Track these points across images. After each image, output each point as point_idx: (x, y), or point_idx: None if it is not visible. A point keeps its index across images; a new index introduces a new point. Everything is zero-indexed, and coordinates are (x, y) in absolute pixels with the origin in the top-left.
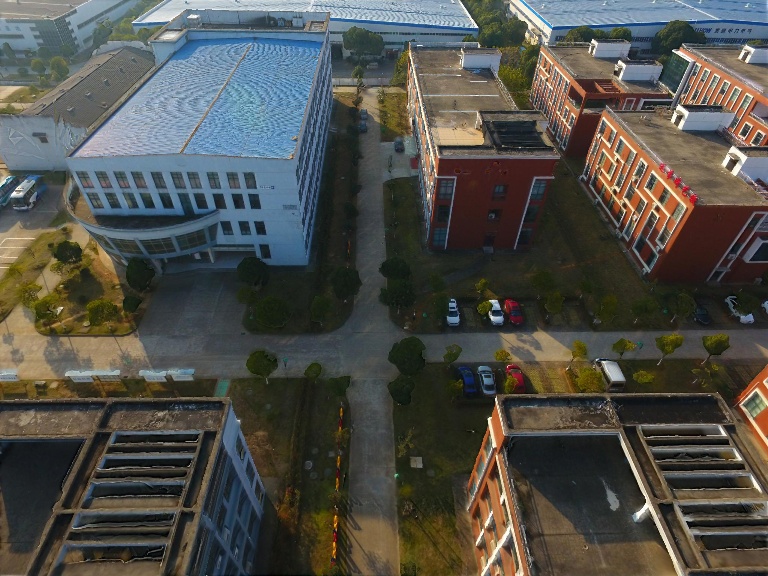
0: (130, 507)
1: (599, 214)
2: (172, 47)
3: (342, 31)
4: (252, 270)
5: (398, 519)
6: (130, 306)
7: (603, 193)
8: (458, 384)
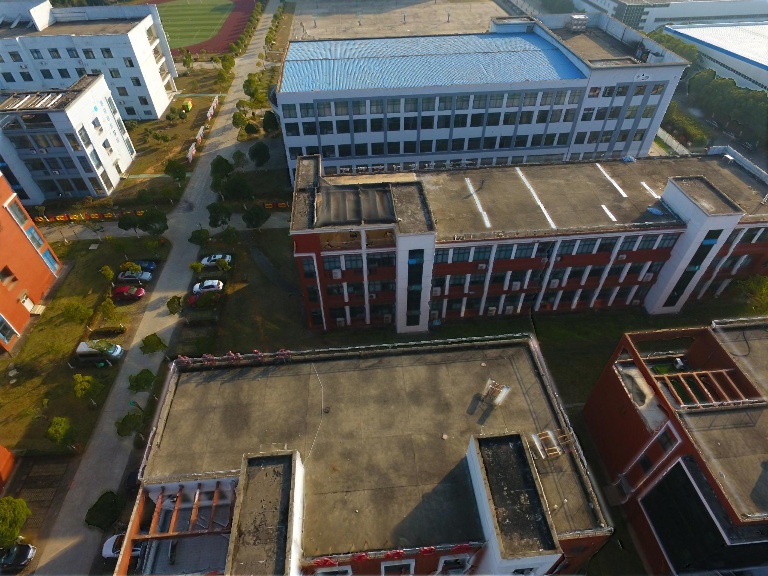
0: (30, 102)
1: None
2: (496, 28)
3: None
4: (252, 148)
5: None
6: (246, 128)
7: None
8: (109, 236)
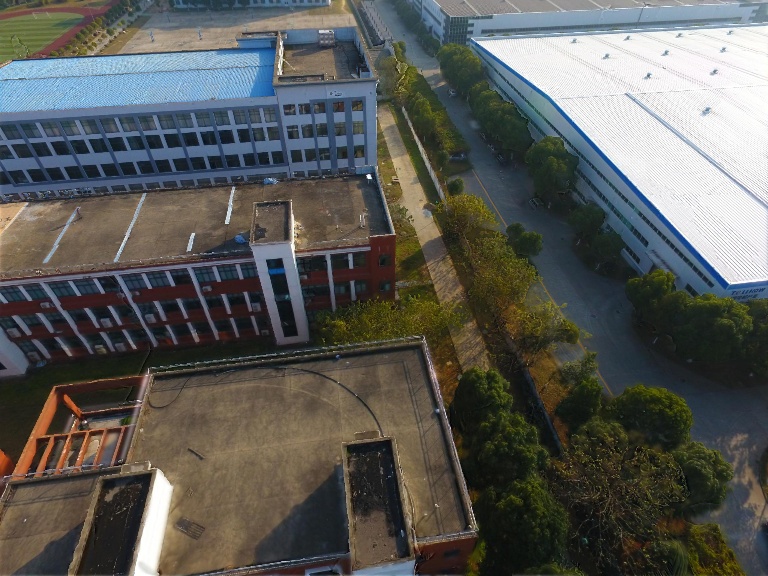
0: None
1: None
2: None
3: (568, 139)
4: None
5: None
6: None
7: None
8: None
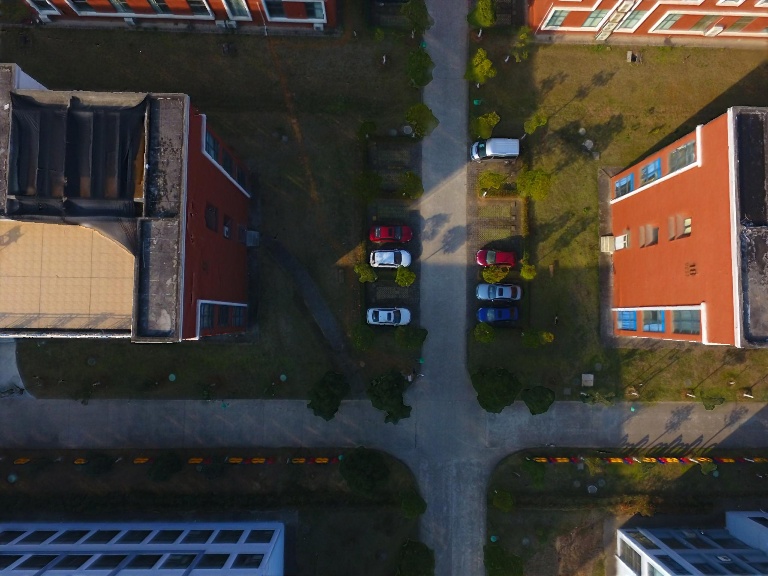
0: None
1: (164, 31)
2: None
3: None
4: None
5: (640, 401)
6: None
7: (122, 5)
8: (549, 338)
